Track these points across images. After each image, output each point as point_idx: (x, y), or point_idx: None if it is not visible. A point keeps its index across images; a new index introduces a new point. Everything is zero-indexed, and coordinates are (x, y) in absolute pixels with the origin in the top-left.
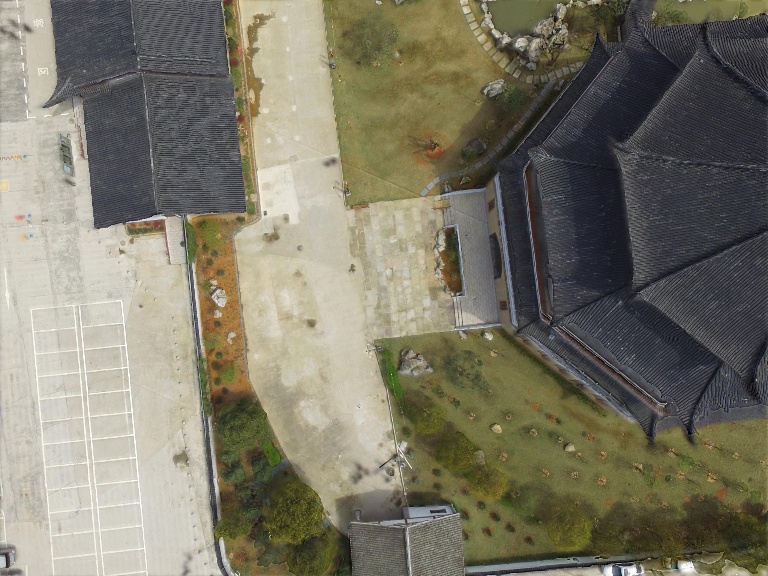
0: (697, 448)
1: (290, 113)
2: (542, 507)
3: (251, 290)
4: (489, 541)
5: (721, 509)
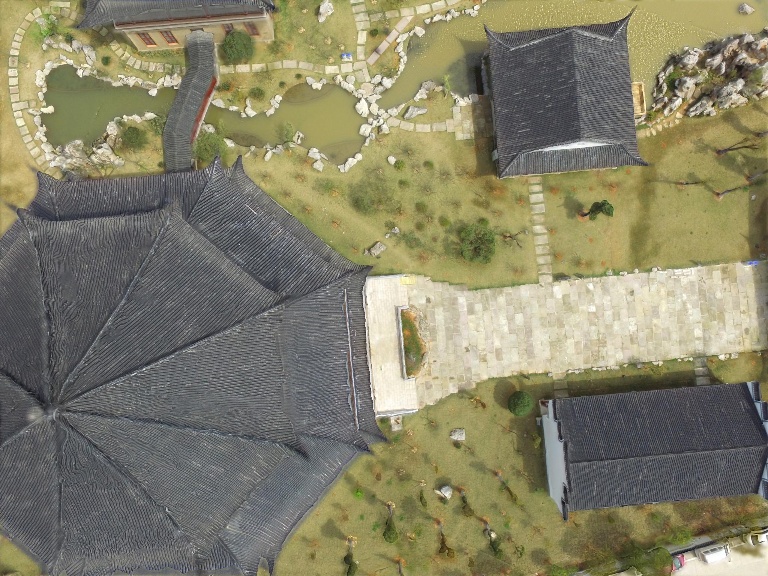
0: (239, 574)
1: None
2: None
3: None
4: None
5: None
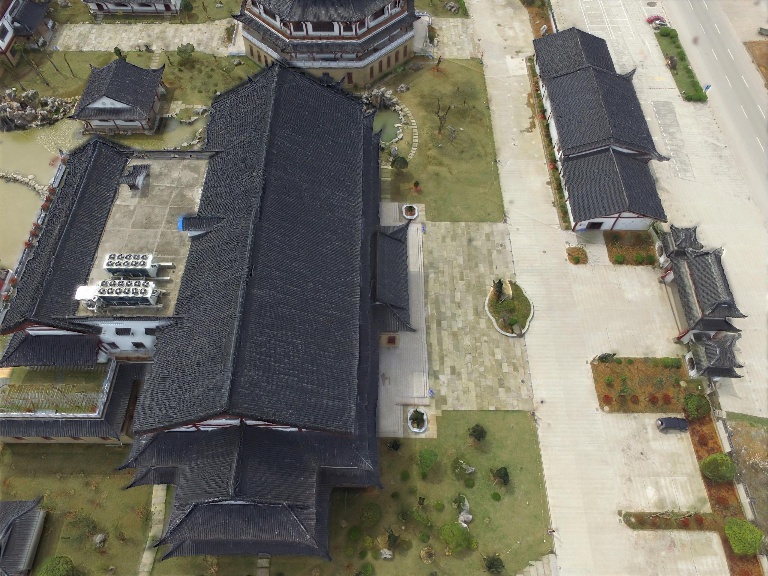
0: None
1: (511, 93)
2: None
3: (529, 37)
4: None
5: None
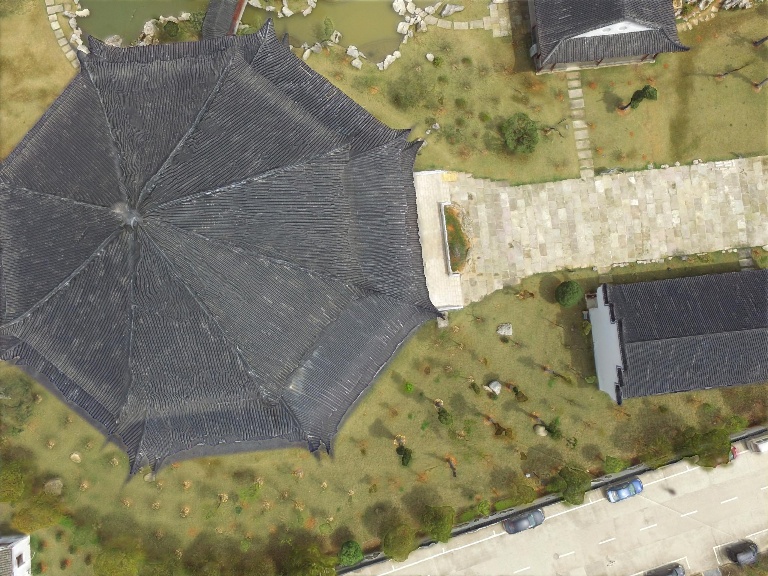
0: (286, 478)
1: None
2: (124, 539)
3: None
4: (68, 575)
5: (282, 543)
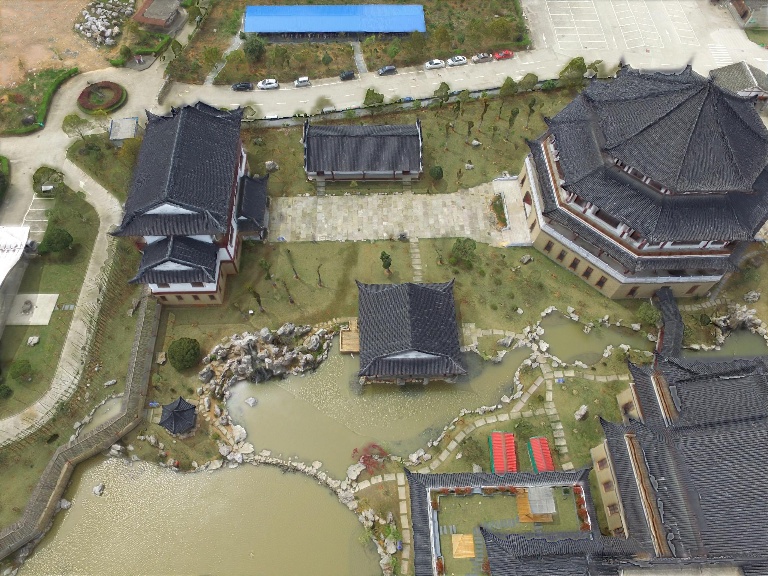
0: None
1: None
2: None
3: None
4: None
5: None
